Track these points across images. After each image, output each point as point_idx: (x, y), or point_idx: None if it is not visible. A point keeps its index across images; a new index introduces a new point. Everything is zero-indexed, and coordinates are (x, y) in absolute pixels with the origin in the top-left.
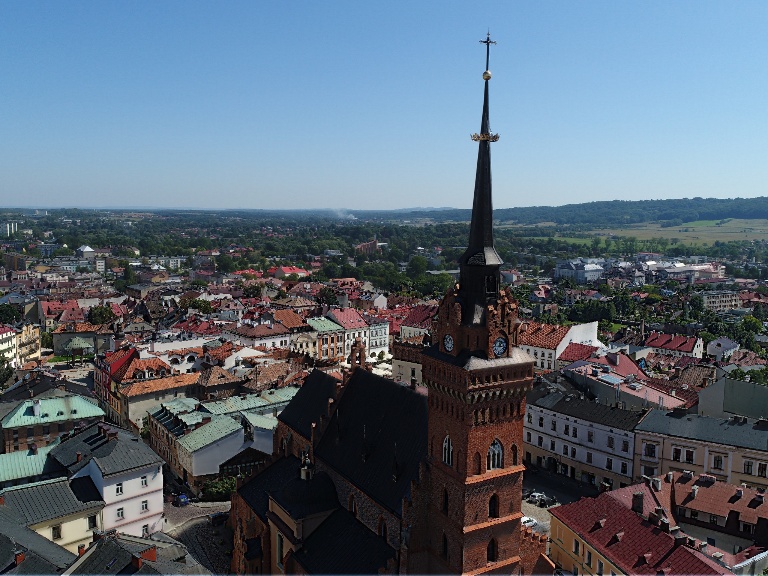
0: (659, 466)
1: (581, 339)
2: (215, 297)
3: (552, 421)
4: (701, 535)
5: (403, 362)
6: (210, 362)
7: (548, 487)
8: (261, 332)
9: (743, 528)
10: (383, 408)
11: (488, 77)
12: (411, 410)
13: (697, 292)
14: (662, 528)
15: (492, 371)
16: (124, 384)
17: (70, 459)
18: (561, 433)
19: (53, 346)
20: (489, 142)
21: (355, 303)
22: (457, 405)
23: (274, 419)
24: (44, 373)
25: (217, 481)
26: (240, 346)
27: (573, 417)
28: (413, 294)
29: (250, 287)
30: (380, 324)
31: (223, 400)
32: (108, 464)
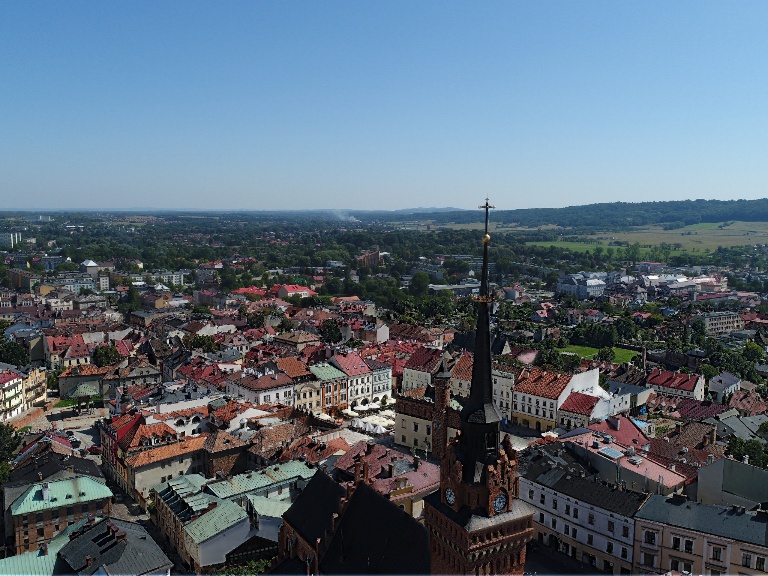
0: (659, 554)
1: (583, 387)
2: (219, 328)
3: (553, 500)
4: None
5: (406, 416)
6: (215, 423)
7: (549, 568)
8: (265, 384)
9: None
10: (386, 532)
11: (487, 240)
12: (414, 541)
13: (699, 314)
14: None
15: (492, 528)
16: (131, 452)
17: (80, 562)
18: (562, 512)
19: (59, 388)
20: (489, 302)
21: (358, 333)
22: (458, 559)
23: (279, 501)
24: (52, 442)
25: (223, 569)
26: (245, 406)
27: (574, 498)
28: (416, 316)
29: (253, 317)
30: (383, 369)
31: (229, 480)
32: (117, 571)
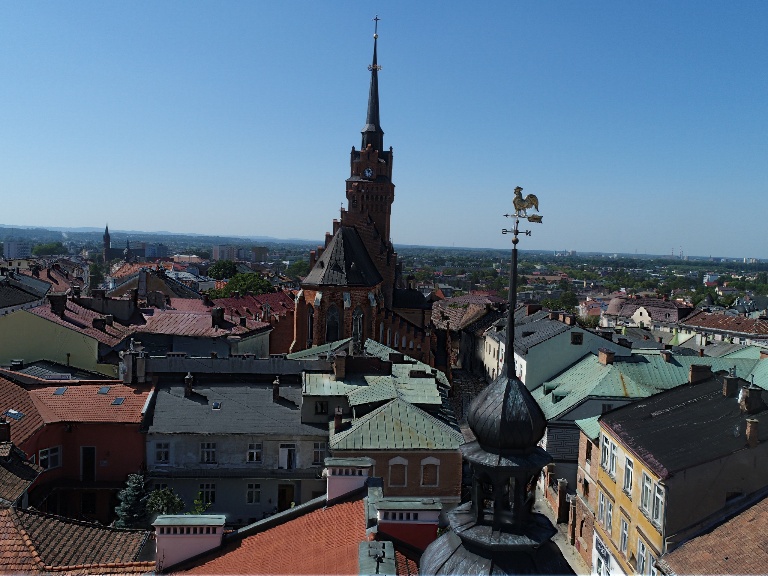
0: None
1: None
2: None
3: None
4: None
5: None
6: None
7: None
8: None
9: None
10: None
11: None
12: None
13: None
14: None
15: None
16: None
17: None
18: None
19: None
20: None
21: None
22: None
23: None
24: None
25: None
26: None
27: None
28: None
29: None
30: None
31: None
32: None
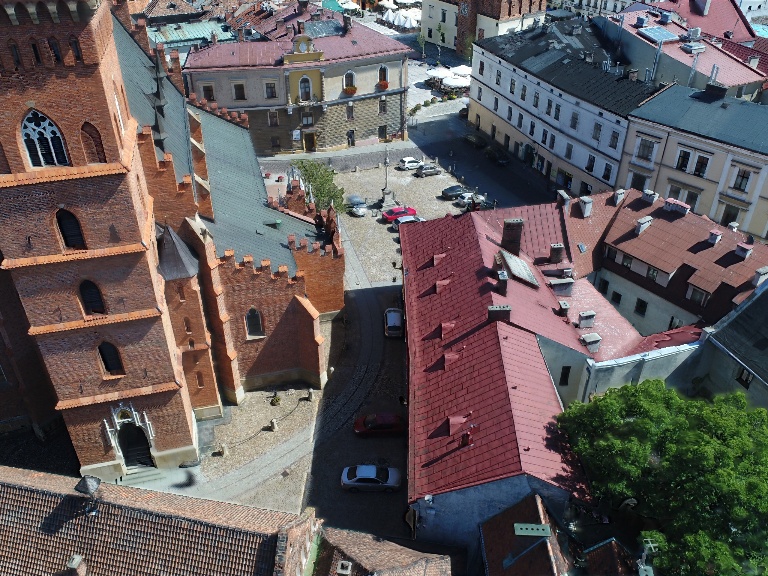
0: (653, 175)
1: None
2: None
3: (535, 92)
4: (629, 292)
5: (433, 0)
6: None
7: (505, 186)
8: None
9: (691, 295)
10: None
11: None
12: None
13: None
14: (497, 285)
15: None
16: None
17: None
18: (542, 111)
19: None
20: None
21: None
22: None
23: None
24: None
25: None
26: None
27: (557, 88)
28: None
29: None
30: None
31: None
32: None
